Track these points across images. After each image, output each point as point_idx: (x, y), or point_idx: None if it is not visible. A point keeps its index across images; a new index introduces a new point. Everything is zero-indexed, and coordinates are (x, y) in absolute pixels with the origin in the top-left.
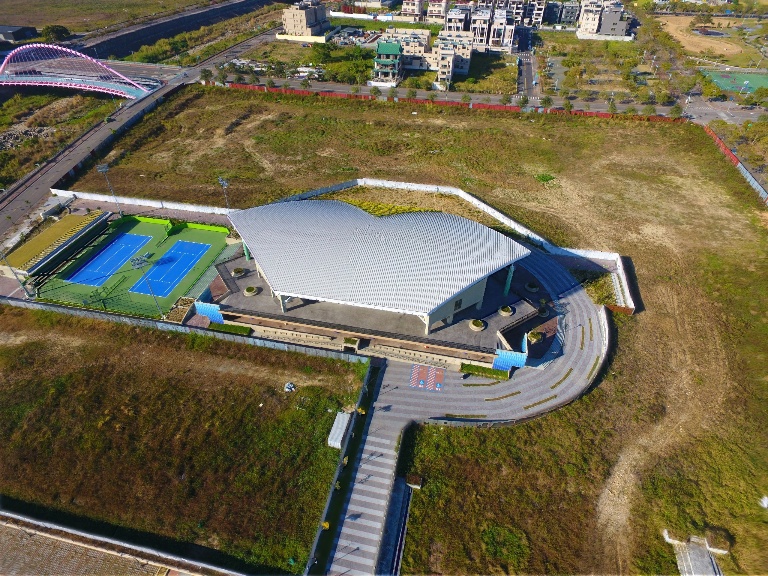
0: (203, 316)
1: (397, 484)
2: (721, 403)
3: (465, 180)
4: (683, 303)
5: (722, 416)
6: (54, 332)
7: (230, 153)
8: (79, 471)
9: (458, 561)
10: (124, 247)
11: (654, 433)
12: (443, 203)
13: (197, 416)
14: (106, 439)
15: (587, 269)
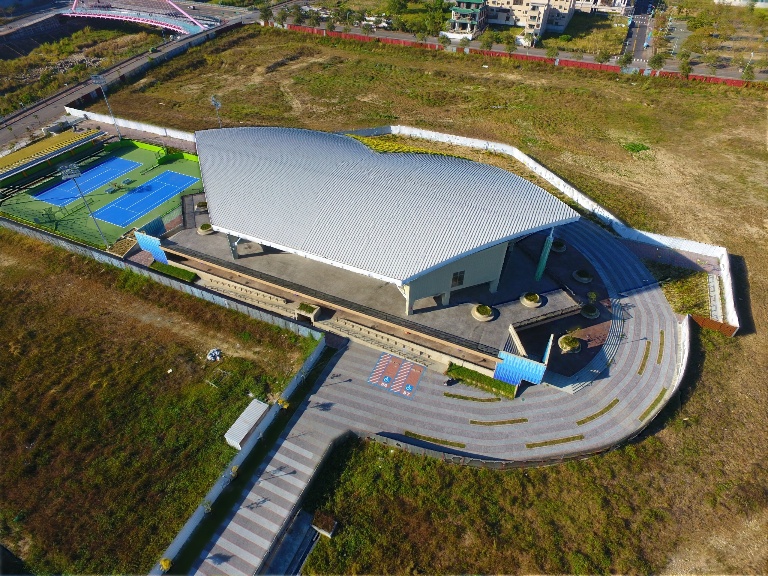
0: None
1: (298, 522)
2: None
3: (527, 140)
4: None
5: None
6: None
7: (262, 90)
8: None
9: None
10: (109, 171)
11: (741, 532)
12: (490, 162)
13: (88, 370)
14: None
15: (672, 264)
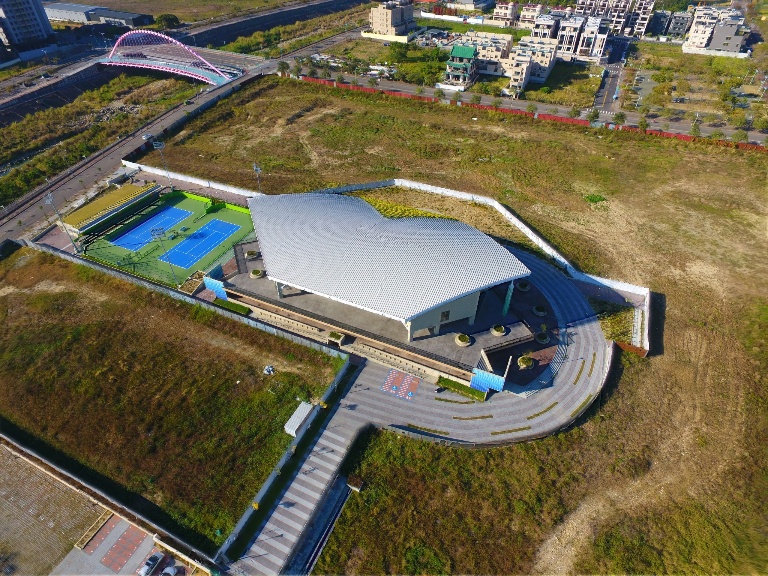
0: (212, 291)
1: (338, 482)
2: (721, 472)
3: (506, 192)
4: (712, 354)
5: (717, 486)
6: (87, 286)
7: (285, 142)
8: (69, 411)
9: (374, 571)
10: (166, 219)
11: (629, 488)
12: (475, 212)
13: (179, 381)
14: (98, 387)
15: (609, 300)
